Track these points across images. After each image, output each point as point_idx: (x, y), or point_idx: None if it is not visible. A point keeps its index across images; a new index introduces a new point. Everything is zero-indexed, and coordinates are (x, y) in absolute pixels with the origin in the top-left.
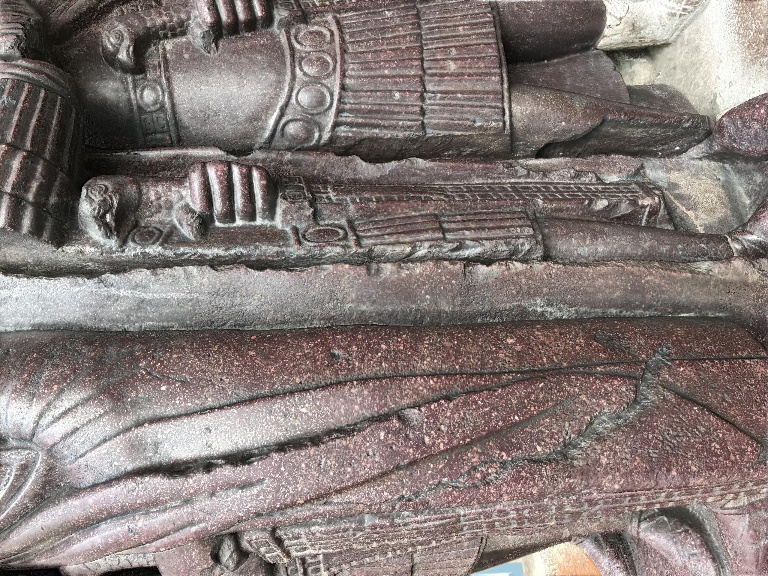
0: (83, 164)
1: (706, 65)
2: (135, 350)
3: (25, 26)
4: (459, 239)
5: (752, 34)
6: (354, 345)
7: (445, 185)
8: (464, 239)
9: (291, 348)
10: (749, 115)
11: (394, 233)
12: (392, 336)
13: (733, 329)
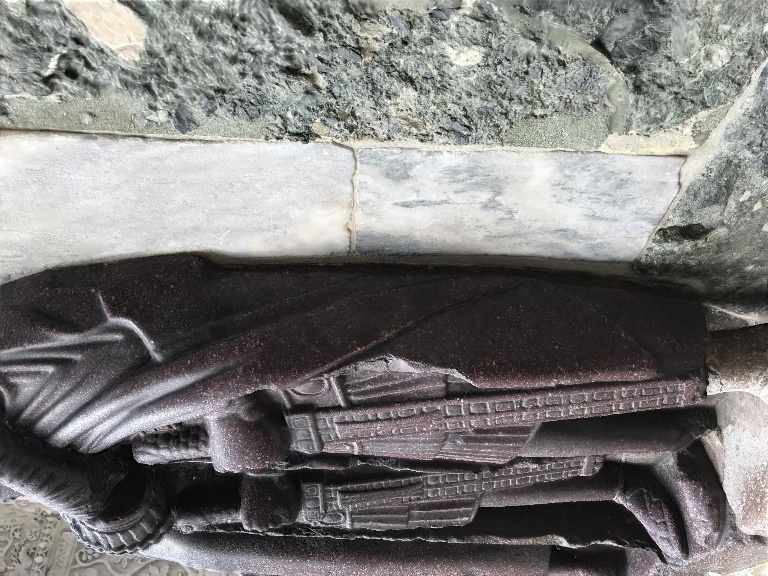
0: (156, 471)
1: (754, 412)
2: (233, 561)
3: (89, 512)
4: (417, 524)
5: (762, 487)
6: (340, 571)
7: (427, 475)
8: (420, 524)
9: (309, 569)
10: (686, 505)
11: (376, 519)
12: (360, 569)
13: (541, 570)
